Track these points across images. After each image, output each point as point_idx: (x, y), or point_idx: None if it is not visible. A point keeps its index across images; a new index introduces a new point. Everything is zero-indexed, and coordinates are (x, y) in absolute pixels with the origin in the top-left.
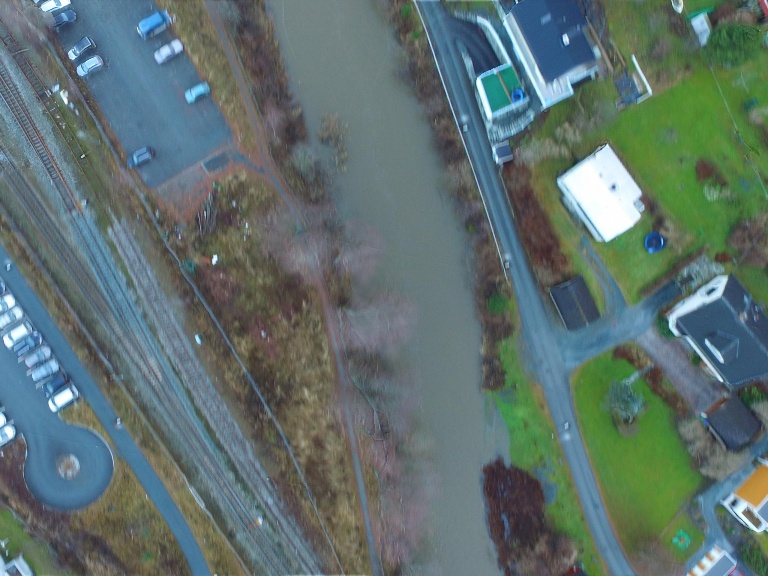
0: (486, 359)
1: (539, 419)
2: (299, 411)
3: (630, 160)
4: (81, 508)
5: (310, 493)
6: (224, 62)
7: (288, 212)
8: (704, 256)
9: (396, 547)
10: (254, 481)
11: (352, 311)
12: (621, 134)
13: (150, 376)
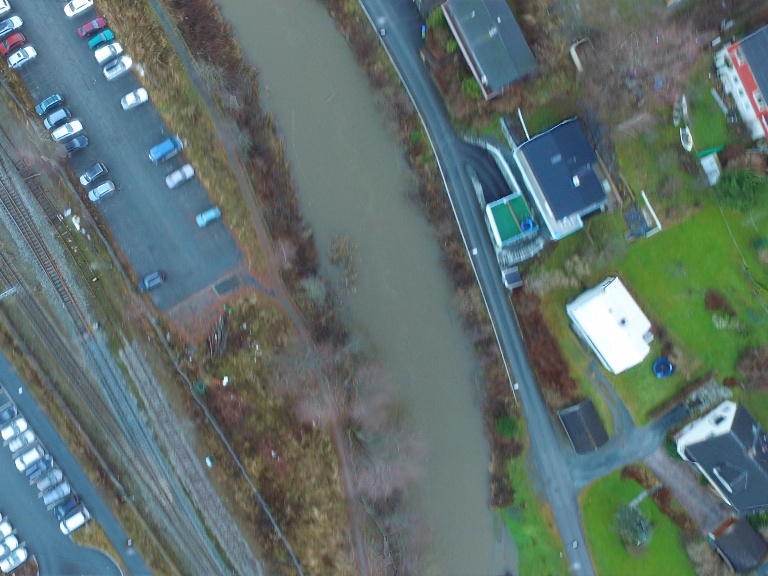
0: (495, 477)
1: (548, 538)
2: (309, 530)
3: (639, 290)
4: None
5: None
6: (235, 186)
7: (298, 334)
8: (712, 381)
9: None
10: None
11: (362, 435)
12: (630, 265)
13: (161, 497)
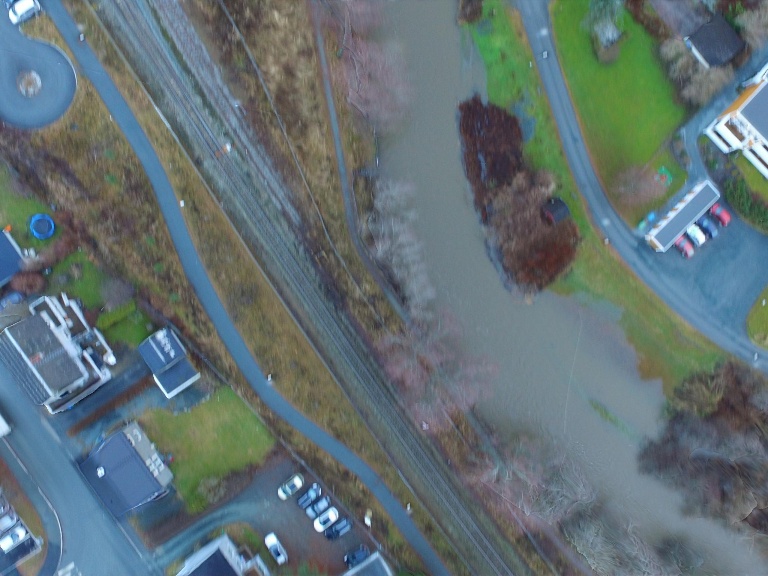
0: None
1: (517, 48)
2: (269, 36)
3: None
4: (43, 126)
5: (280, 118)
6: None
7: None
8: None
9: (369, 180)
10: (222, 107)
11: None
12: None
13: None
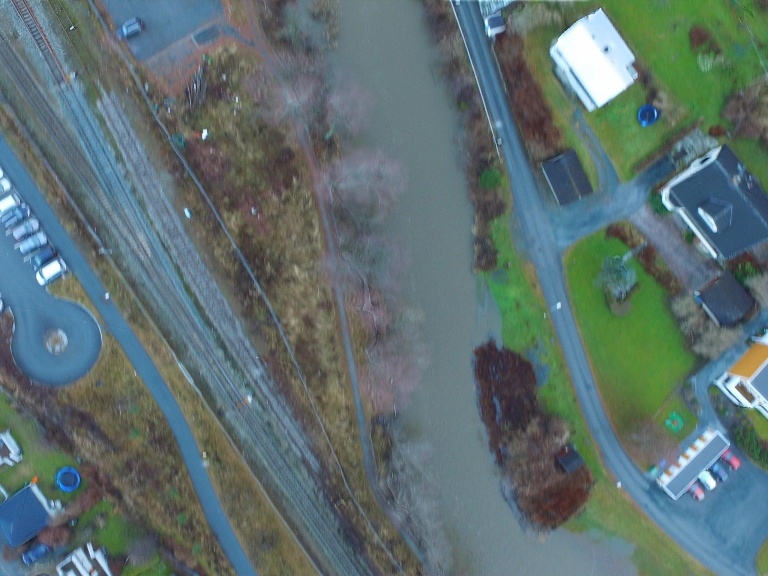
0: (478, 239)
1: (531, 299)
2: (289, 289)
3: (623, 27)
4: (69, 383)
5: (300, 371)
6: None
7: (279, 86)
8: (698, 130)
9: (387, 427)
10: (243, 359)
11: (343, 184)
12: None
13: (139, 251)
